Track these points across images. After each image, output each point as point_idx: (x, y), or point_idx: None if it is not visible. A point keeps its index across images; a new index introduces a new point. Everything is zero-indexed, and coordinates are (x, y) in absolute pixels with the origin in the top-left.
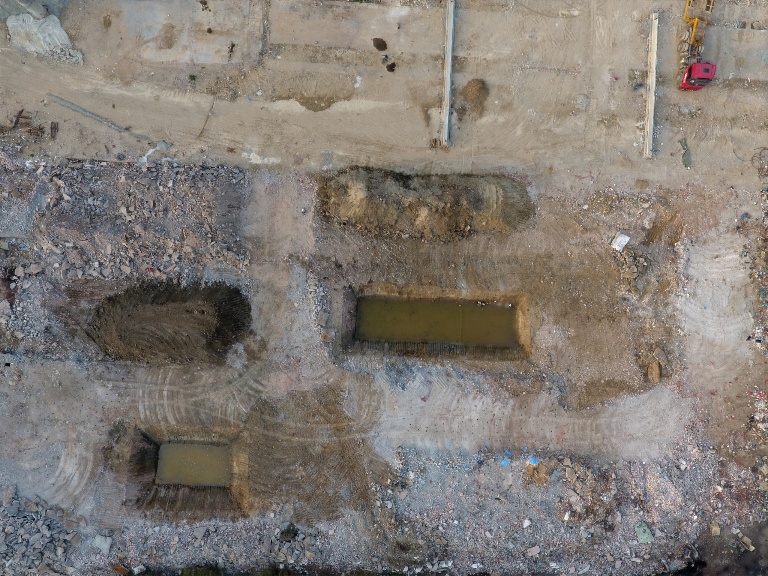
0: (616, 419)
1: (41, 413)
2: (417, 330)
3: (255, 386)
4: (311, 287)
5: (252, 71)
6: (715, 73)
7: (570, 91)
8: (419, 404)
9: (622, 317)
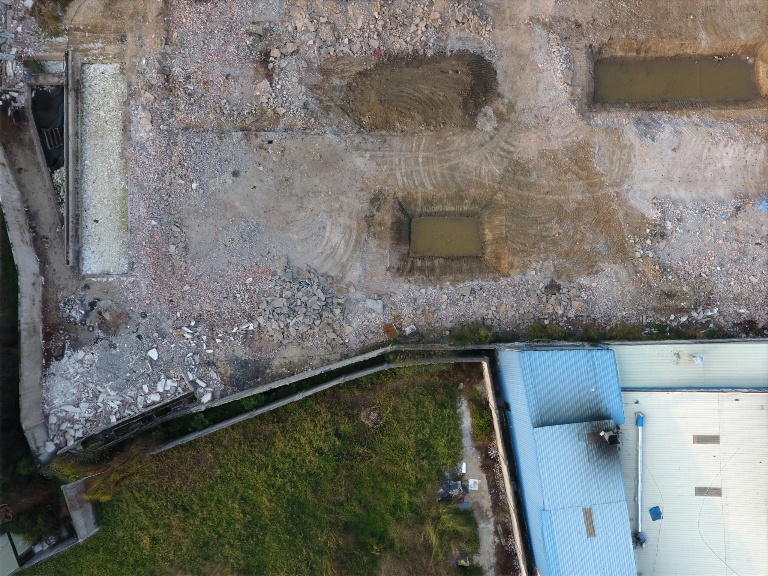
0: None
1: (305, 186)
2: (655, 90)
3: (506, 147)
4: (554, 47)
5: None
6: None
7: None
8: (670, 155)
9: None
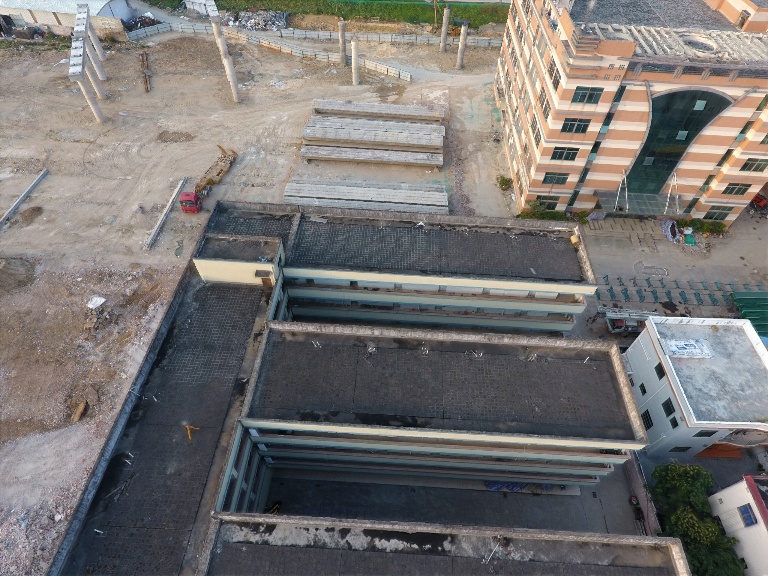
0: (9, 459)
1: None
2: None
3: None
4: None
5: None
6: None
7: (104, 213)
8: None
9: (70, 361)
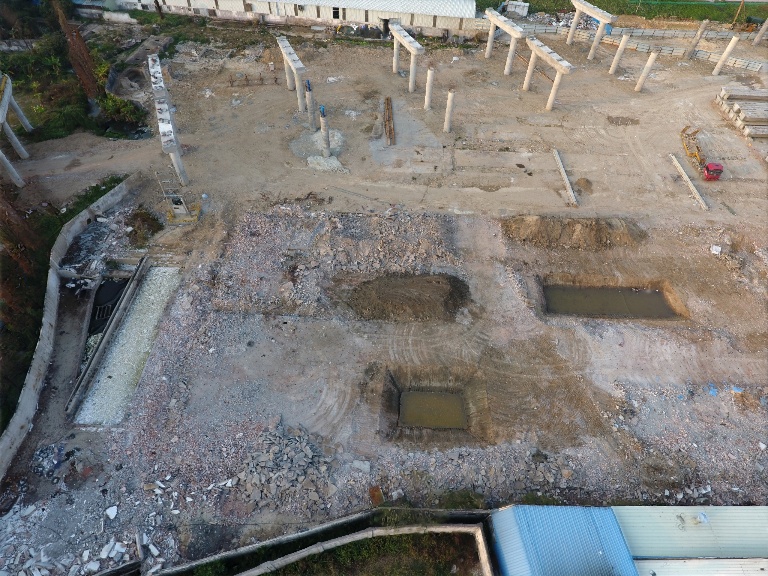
0: None
1: (308, 357)
2: (594, 307)
3: (482, 336)
4: (510, 274)
5: (449, 176)
6: (721, 176)
7: (640, 183)
8: (618, 349)
9: (745, 292)
